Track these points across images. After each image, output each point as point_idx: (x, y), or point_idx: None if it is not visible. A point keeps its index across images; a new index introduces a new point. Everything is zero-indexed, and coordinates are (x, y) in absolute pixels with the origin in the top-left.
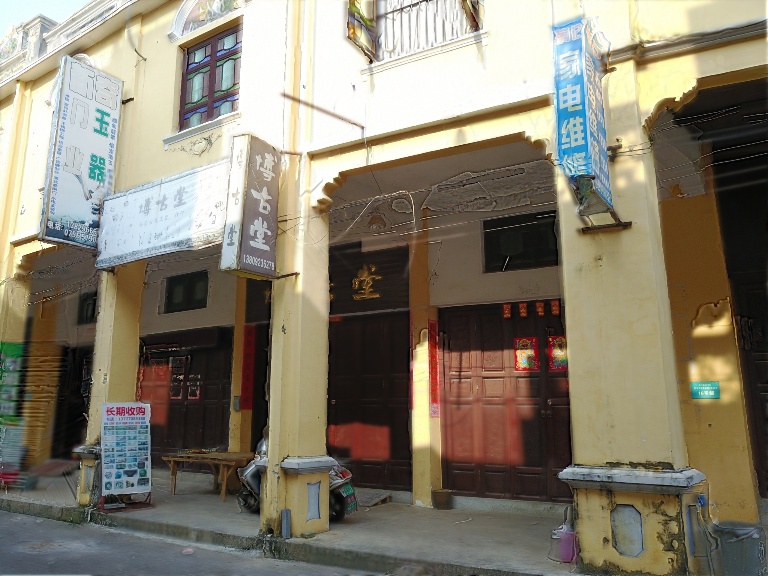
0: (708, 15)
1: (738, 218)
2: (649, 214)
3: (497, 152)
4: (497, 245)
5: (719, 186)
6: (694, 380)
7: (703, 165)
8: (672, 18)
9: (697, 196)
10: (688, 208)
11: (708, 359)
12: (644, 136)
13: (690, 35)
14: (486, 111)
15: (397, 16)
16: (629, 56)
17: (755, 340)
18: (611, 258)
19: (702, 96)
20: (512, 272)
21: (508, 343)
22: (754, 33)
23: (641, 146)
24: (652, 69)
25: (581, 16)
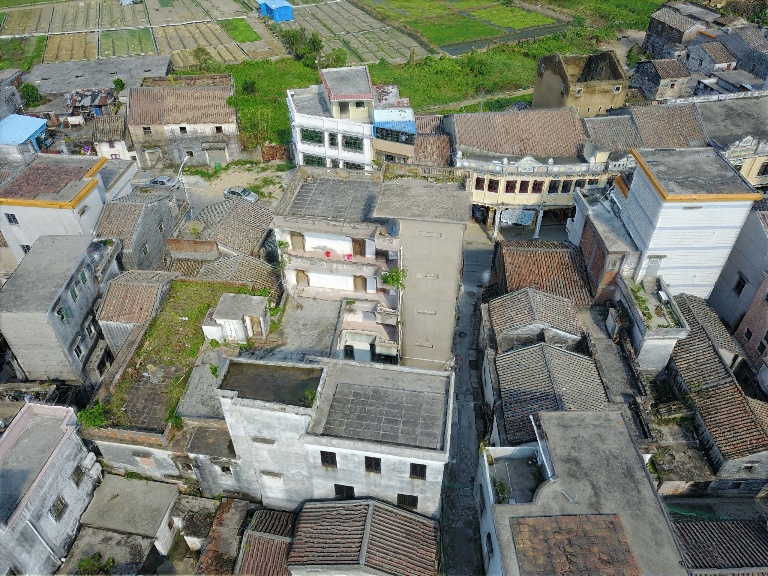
0: None
1: None
2: None
3: None
4: None
5: None
6: None
7: None
8: None
9: None
10: None
11: None
12: None
13: None
14: None
15: None
16: None
17: None
18: None
19: None
20: None
21: None
22: None
23: None
24: None
25: None
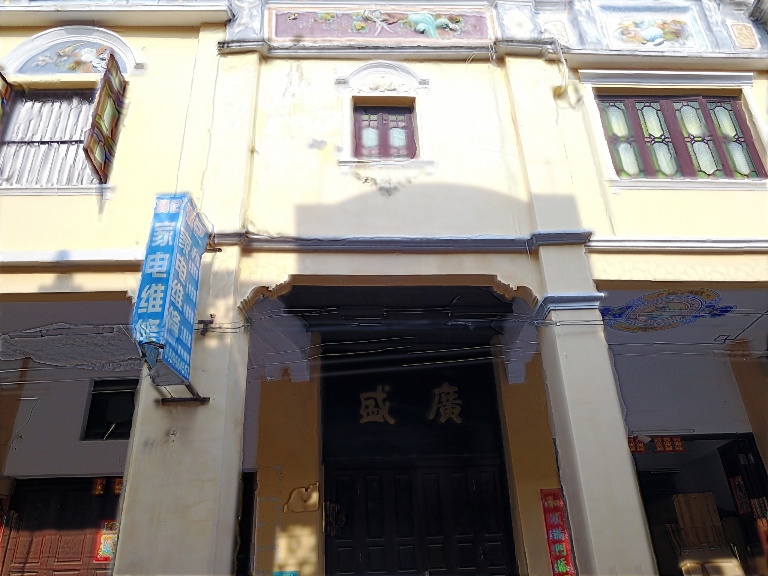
0: (303, 224)
1: (337, 407)
2: (228, 392)
3: (98, 307)
4: (104, 409)
5: (325, 376)
6: (279, 570)
7: (312, 355)
8: (276, 219)
9: (302, 382)
10: (294, 392)
11: (294, 546)
12: (237, 316)
13: (287, 237)
14: (90, 263)
15: (21, 148)
16: (234, 242)
17: (340, 526)
18: (184, 434)
19: (304, 292)
20: (114, 441)
21: (94, 526)
22: (334, 247)
23: (230, 325)
24: (253, 258)
25: (200, 197)
